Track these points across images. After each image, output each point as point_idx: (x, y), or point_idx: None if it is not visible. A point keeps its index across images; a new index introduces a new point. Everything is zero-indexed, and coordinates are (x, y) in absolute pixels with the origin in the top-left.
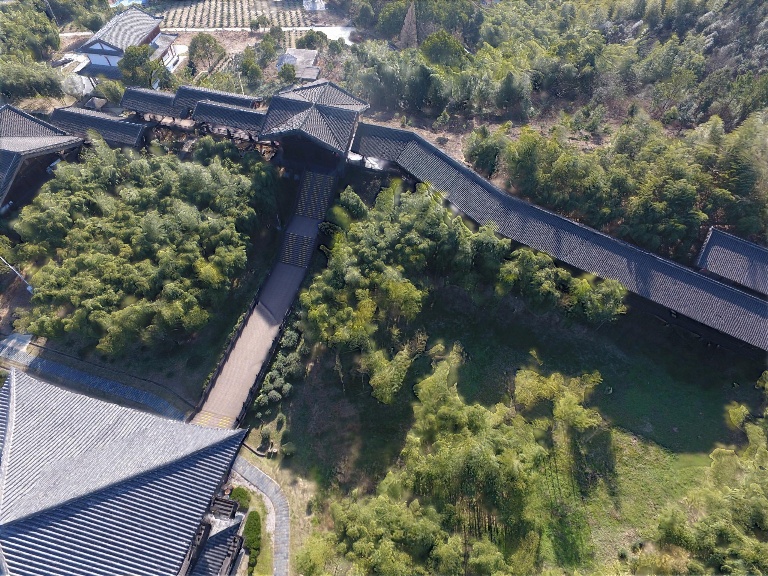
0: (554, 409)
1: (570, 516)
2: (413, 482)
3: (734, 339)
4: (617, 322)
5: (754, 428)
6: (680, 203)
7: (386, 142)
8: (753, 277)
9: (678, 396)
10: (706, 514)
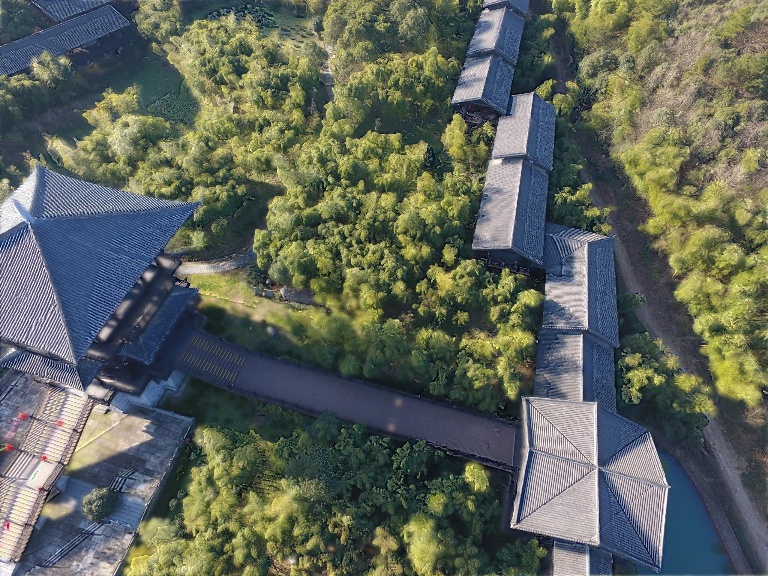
0: (118, 112)
1: None
2: (129, 166)
3: (115, 34)
4: (79, 84)
5: (164, 45)
6: (2, 2)
7: None
8: (79, 6)
9: (142, 81)
10: (194, 72)
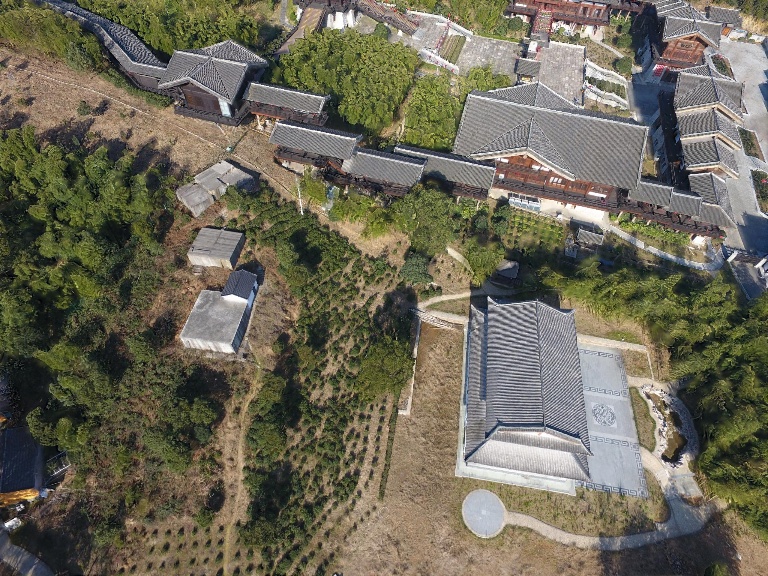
0: None
1: (166, 5)
2: None
3: None
4: None
5: None
6: None
7: (161, 65)
8: None
9: None
10: None
